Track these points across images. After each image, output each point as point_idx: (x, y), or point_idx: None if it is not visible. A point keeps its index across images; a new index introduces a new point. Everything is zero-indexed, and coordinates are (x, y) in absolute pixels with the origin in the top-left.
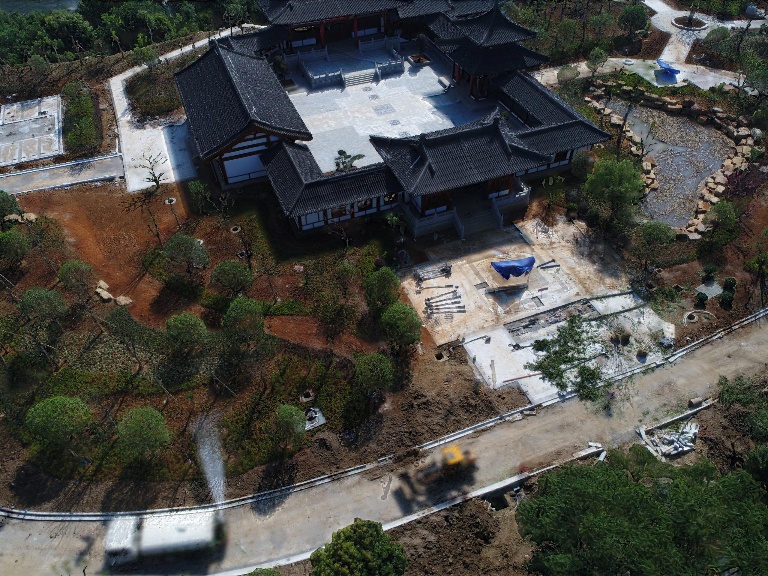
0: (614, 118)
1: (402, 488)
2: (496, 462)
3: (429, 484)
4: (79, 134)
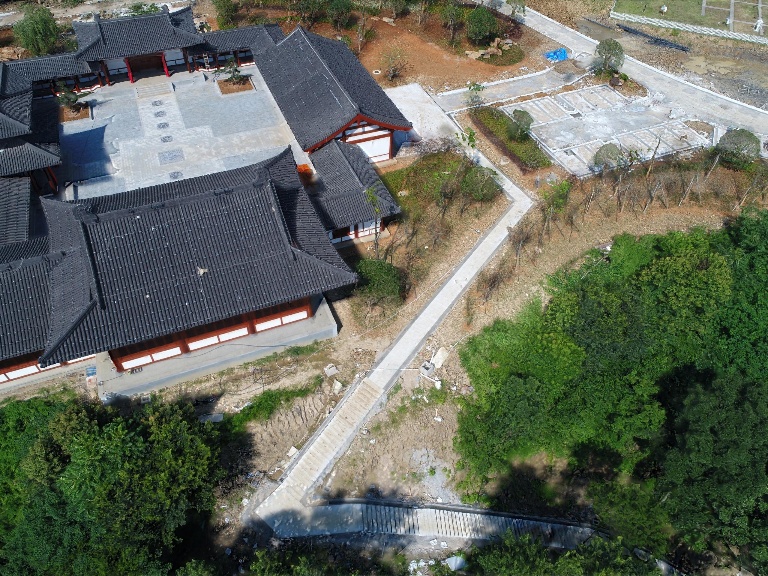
0: None
1: None
2: None
3: None
4: (496, 117)
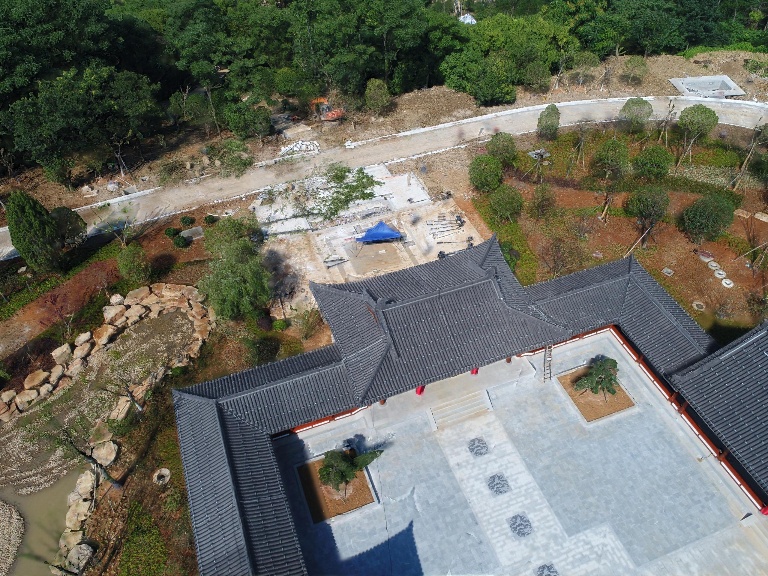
0: (76, 567)
1: (472, 132)
2: (415, 141)
3: (456, 133)
4: None
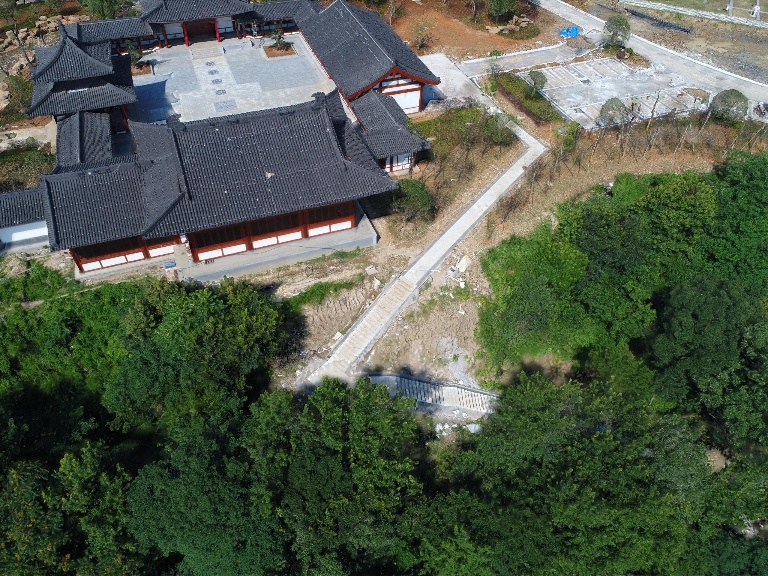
0: None
1: None
2: None
3: None
4: (514, 80)
